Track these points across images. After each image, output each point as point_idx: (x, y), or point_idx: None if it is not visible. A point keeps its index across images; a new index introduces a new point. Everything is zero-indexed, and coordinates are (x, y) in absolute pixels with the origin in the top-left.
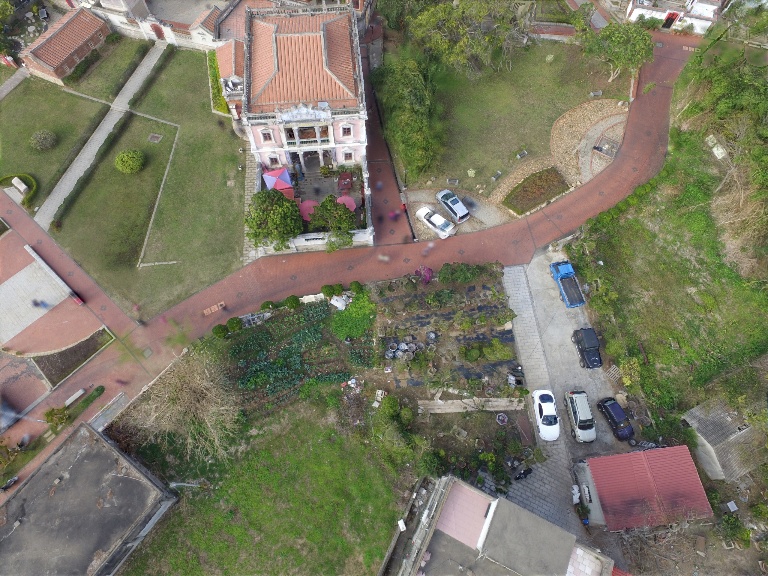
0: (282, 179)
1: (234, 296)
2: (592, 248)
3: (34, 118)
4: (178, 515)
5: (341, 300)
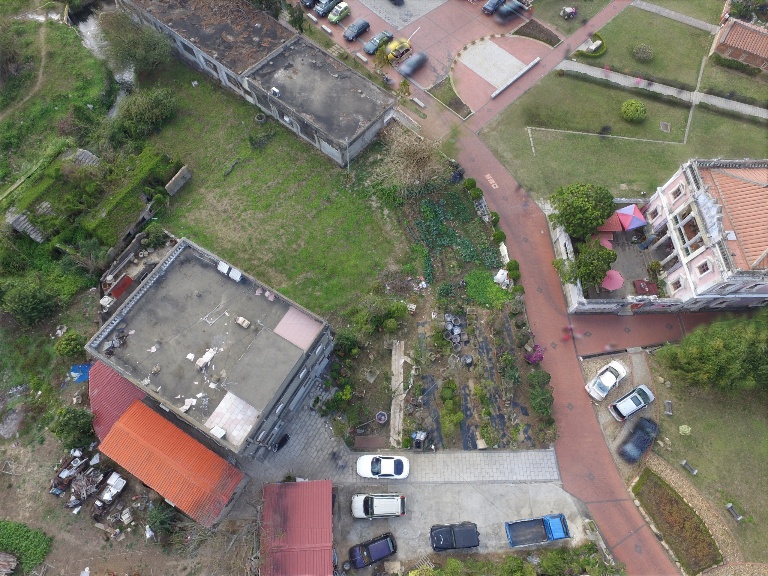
0: (632, 220)
1: (504, 195)
2: (590, 572)
3: (666, 44)
4: (332, 167)
5: (504, 278)
